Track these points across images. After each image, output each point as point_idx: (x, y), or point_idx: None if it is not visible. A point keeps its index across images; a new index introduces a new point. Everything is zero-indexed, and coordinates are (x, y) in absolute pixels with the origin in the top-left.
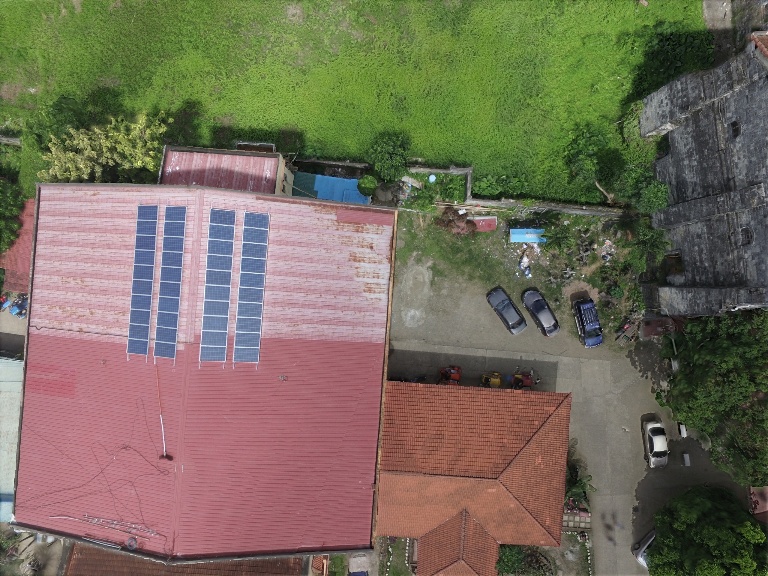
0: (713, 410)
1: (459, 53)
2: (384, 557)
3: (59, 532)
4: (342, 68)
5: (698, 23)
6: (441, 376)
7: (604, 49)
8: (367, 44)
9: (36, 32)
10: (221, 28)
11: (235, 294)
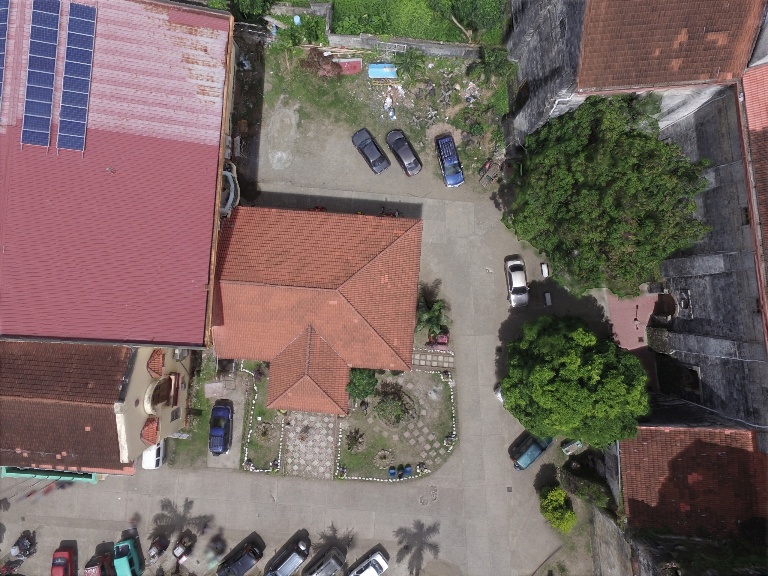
0: (547, 219)
1: None
2: (249, 395)
3: None
4: None
5: None
6: None
7: None
8: None
9: None
10: None
11: (60, 83)
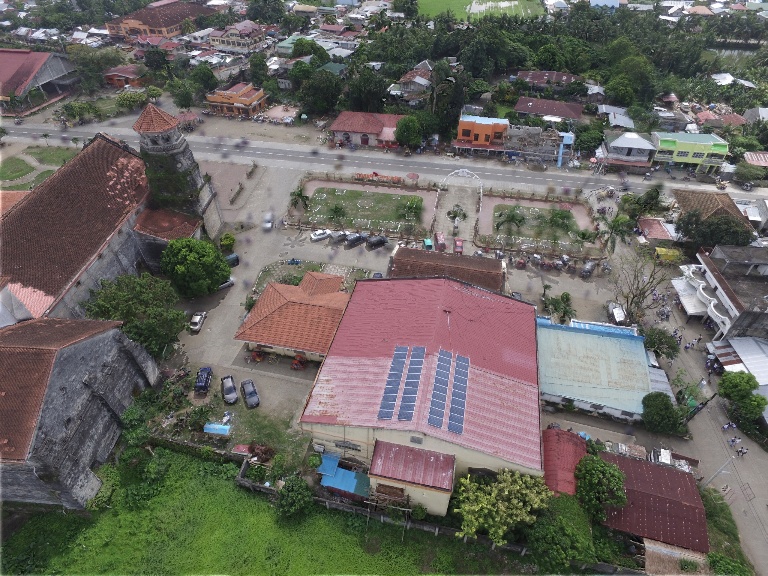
0: None
1: None
2: None
3: (507, 297)
4: None
5: None
6: (303, 365)
7: None
8: None
9: None
10: None
11: (404, 377)
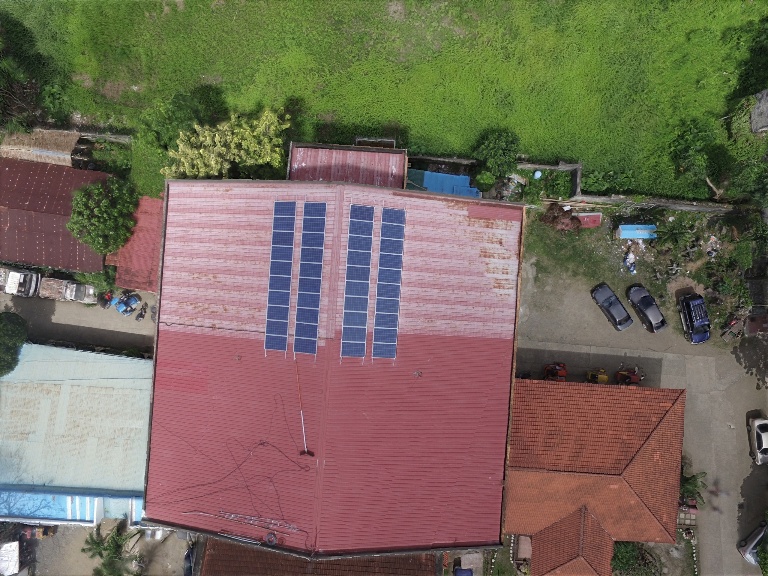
0: None
1: (563, 49)
2: (489, 554)
3: (193, 528)
4: (446, 64)
5: None
6: (547, 373)
7: (709, 44)
8: (470, 40)
9: (139, 30)
10: (323, 25)
11: (373, 290)
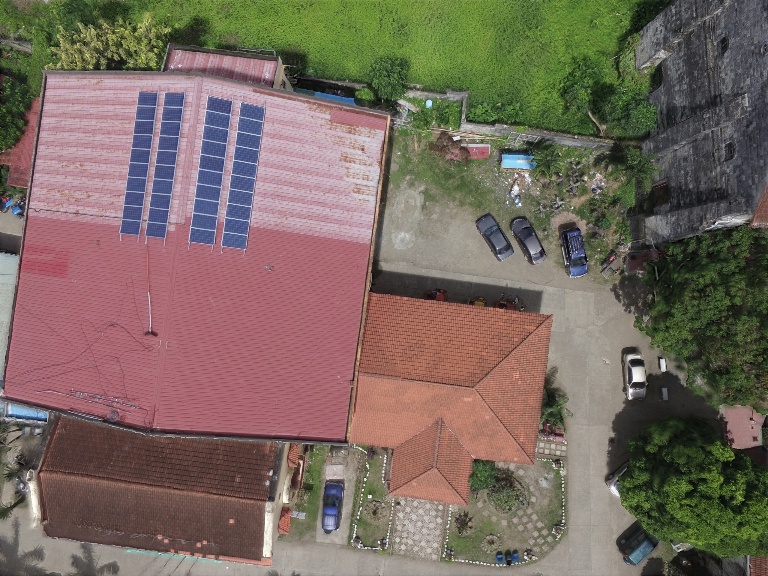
0: (690, 330)
1: None
2: (361, 473)
3: (45, 405)
4: None
5: None
6: (427, 297)
7: None
8: None
9: None
10: None
11: (227, 181)
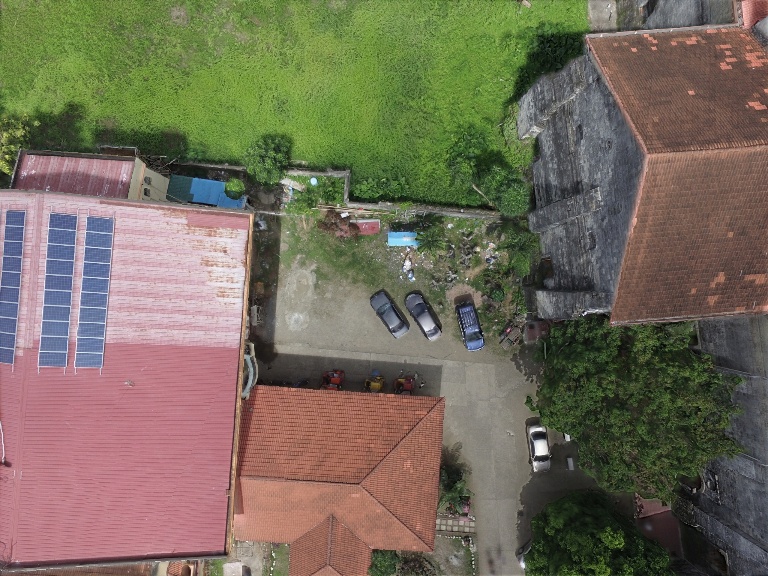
0: (574, 415)
1: (341, 55)
2: (267, 562)
3: None
4: (224, 70)
5: (580, 25)
6: (323, 380)
7: (487, 51)
8: (251, 46)
9: None
10: (104, 30)
11: (77, 299)
